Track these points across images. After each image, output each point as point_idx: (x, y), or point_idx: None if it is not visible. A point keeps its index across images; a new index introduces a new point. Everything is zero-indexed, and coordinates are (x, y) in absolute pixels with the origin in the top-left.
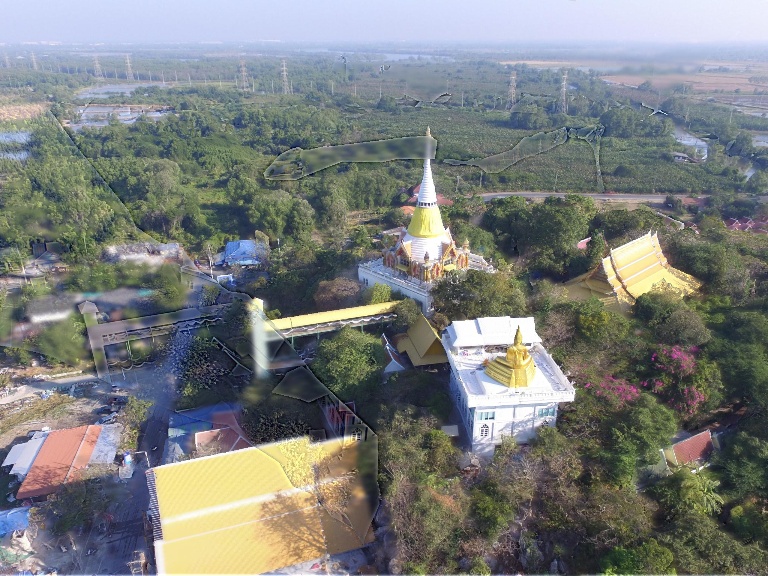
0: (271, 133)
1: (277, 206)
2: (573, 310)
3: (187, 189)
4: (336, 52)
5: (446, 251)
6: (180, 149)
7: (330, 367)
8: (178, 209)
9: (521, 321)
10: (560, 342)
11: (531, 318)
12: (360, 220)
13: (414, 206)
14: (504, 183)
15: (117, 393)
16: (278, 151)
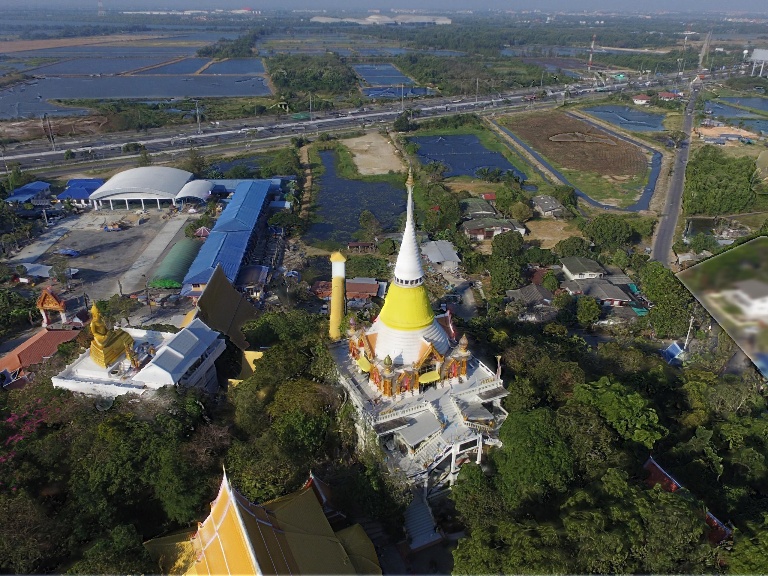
0: None
1: None
2: None
3: None
4: None
5: None
6: None
7: None
8: None
9: None
10: None
11: (153, 361)
12: None
13: None
14: None
15: None
16: None
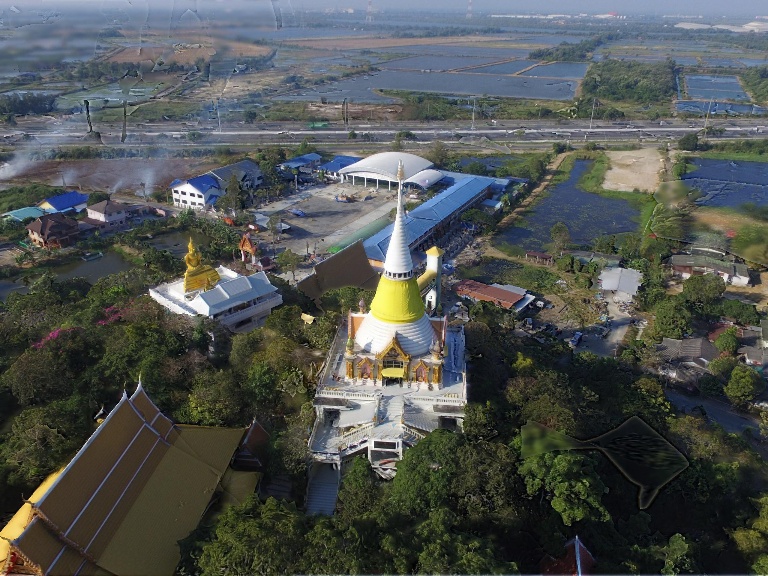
0: None
1: None
2: None
3: None
4: None
5: None
6: None
7: None
8: None
9: None
10: None
11: (201, 293)
12: None
13: None
14: None
15: None
16: None
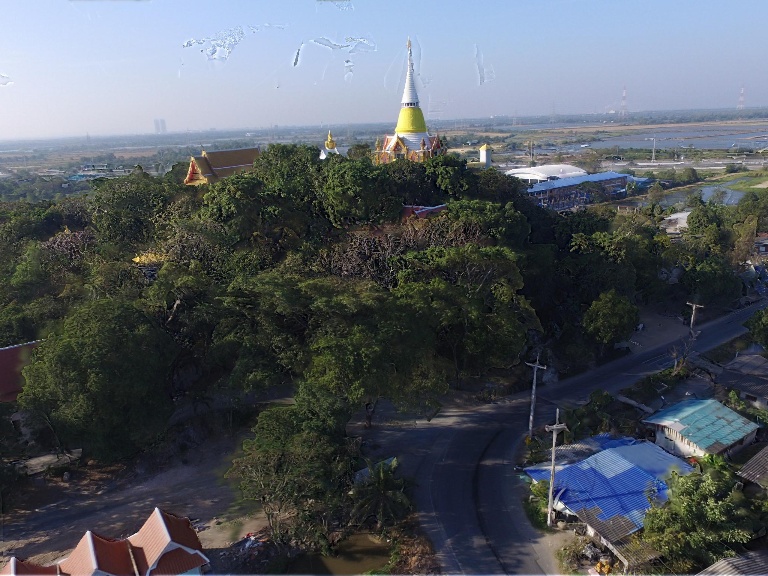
0: None
1: None
2: None
3: None
4: None
5: None
6: None
7: None
8: None
9: None
10: None
11: None
12: None
13: None
14: None
15: None
16: None
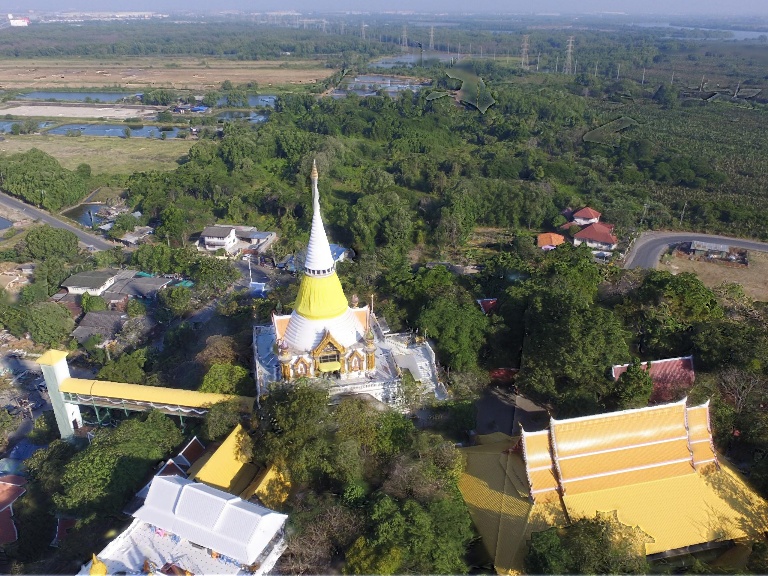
0: (493, 119)
1: (368, 212)
2: (377, 518)
3: (353, 172)
4: (412, 37)
5: (320, 344)
6: (382, 128)
7: (67, 468)
8: (293, 197)
9: (240, 515)
10: (307, 570)
11: (257, 516)
12: (485, 241)
13: (563, 235)
14: (725, 221)
15: (43, 393)
16: (482, 141)
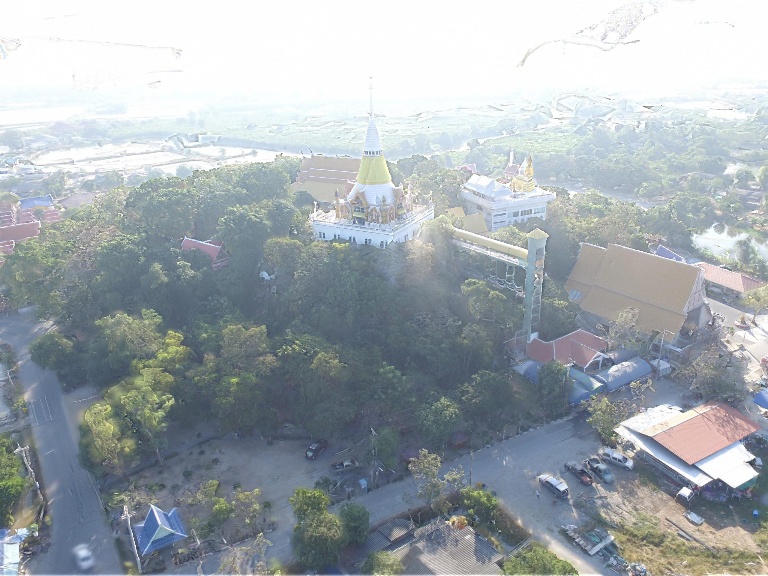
0: None
1: None
2: None
3: None
4: None
5: None
6: None
7: None
8: None
9: None
10: None
11: None
12: None
13: None
14: None
15: None
16: None
